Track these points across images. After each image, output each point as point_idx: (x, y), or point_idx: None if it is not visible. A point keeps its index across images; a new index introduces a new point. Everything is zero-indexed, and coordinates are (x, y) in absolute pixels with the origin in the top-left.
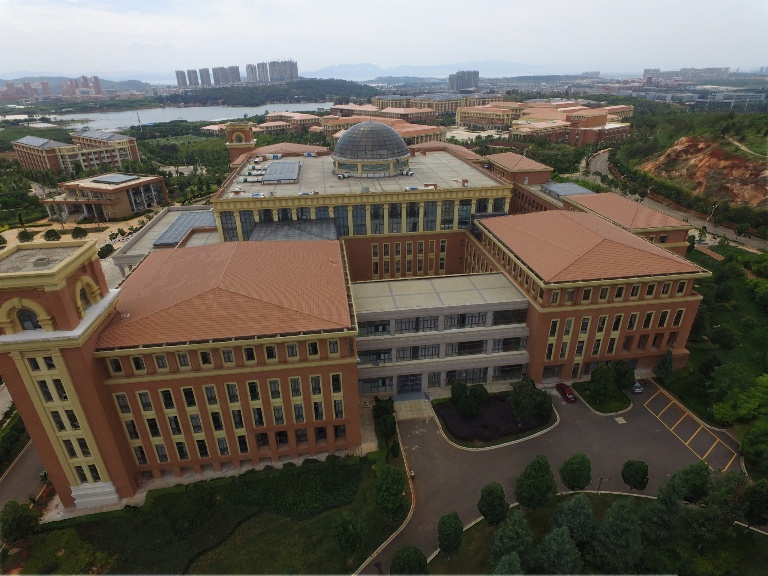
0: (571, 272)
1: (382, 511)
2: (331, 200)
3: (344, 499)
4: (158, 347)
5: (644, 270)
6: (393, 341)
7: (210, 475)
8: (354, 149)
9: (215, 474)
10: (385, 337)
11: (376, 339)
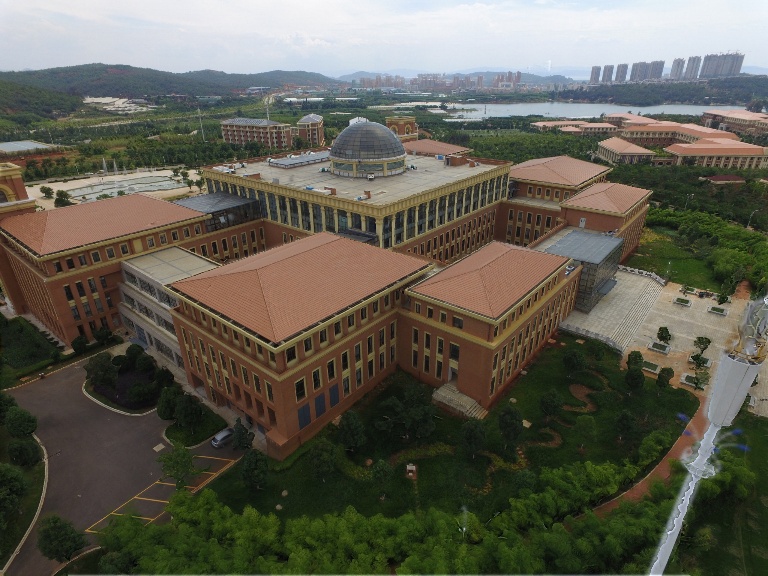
0: (192, 285)
1: (6, 380)
2: (255, 184)
3: (16, 364)
4: (2, 231)
5: (234, 312)
6: (133, 293)
7: (39, 324)
8: (333, 146)
9: (40, 325)
10: (137, 289)
11: (133, 288)
